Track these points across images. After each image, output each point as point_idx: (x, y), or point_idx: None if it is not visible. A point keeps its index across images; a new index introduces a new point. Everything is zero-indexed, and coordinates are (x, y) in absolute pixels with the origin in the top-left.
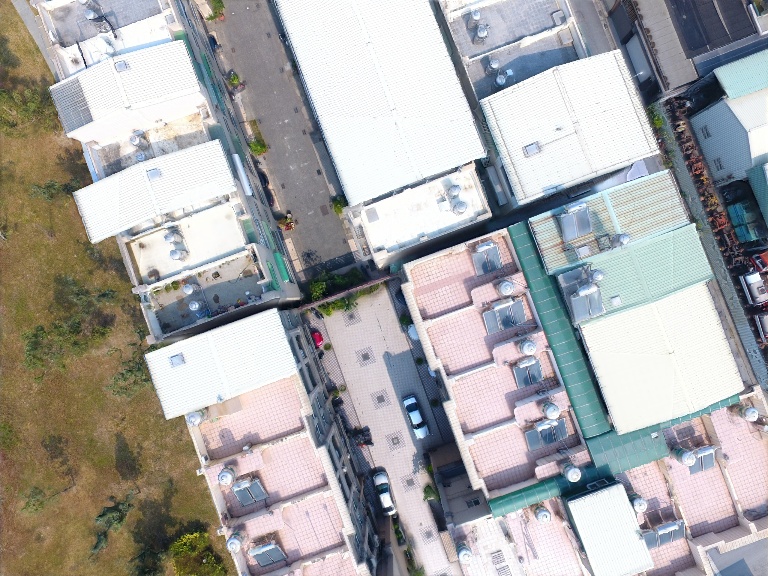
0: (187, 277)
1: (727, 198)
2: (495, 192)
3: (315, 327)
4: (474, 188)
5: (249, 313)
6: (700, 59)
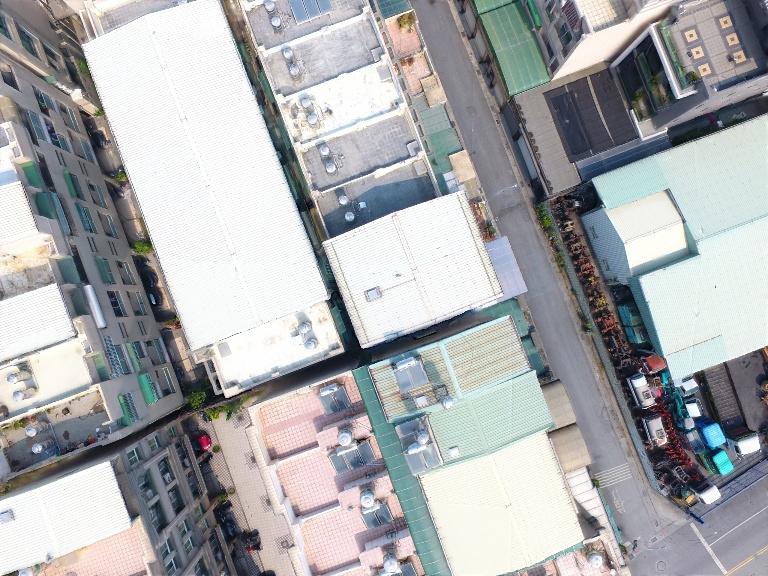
0: (36, 414)
1: (617, 297)
2: (351, 323)
3: (204, 429)
4: (329, 321)
5: (96, 453)
6: (583, 163)
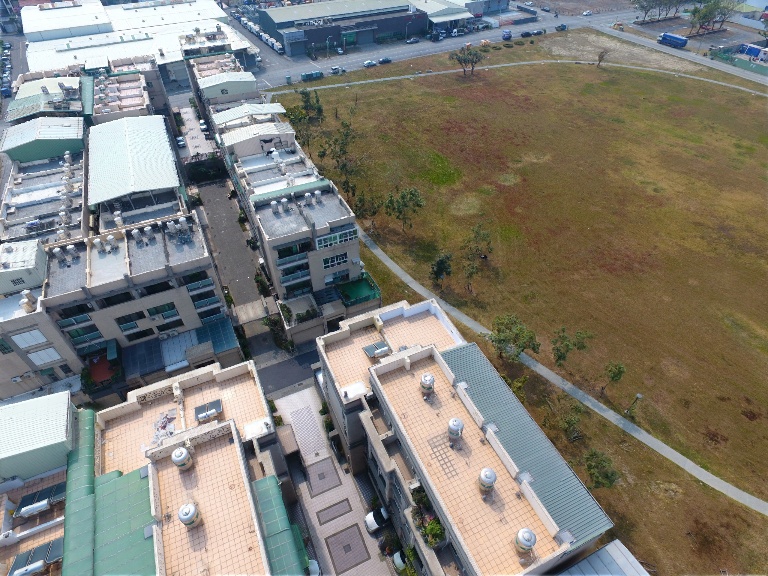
0: None
1: None
2: None
3: None
4: None
5: None
6: None
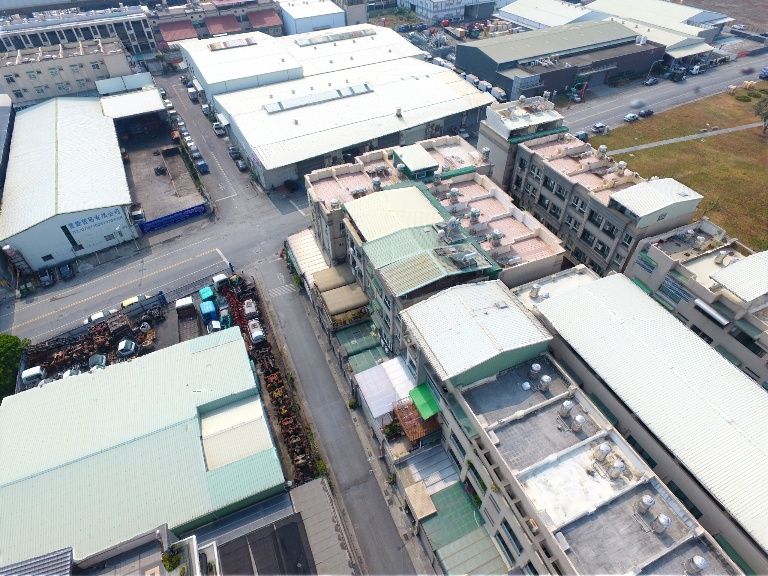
0: None
1: None
2: None
3: None
4: None
5: None
6: (286, 512)
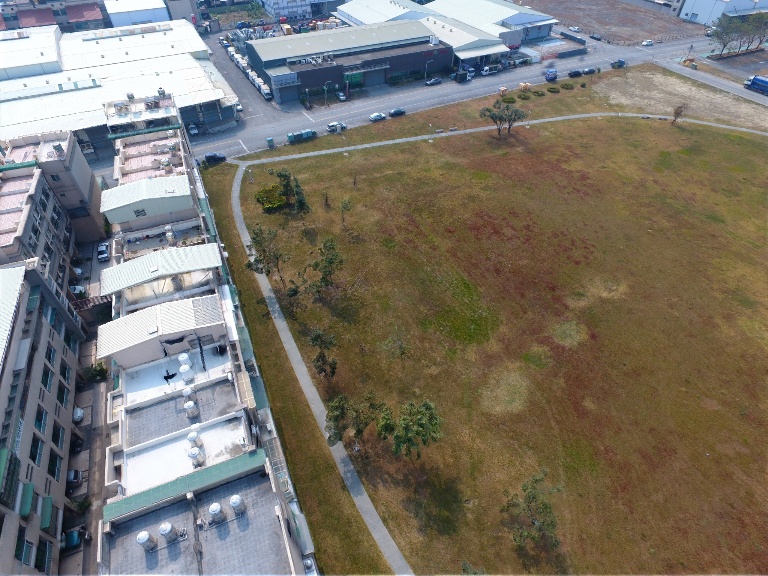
0: None
1: None
2: None
3: None
4: None
5: None
6: None
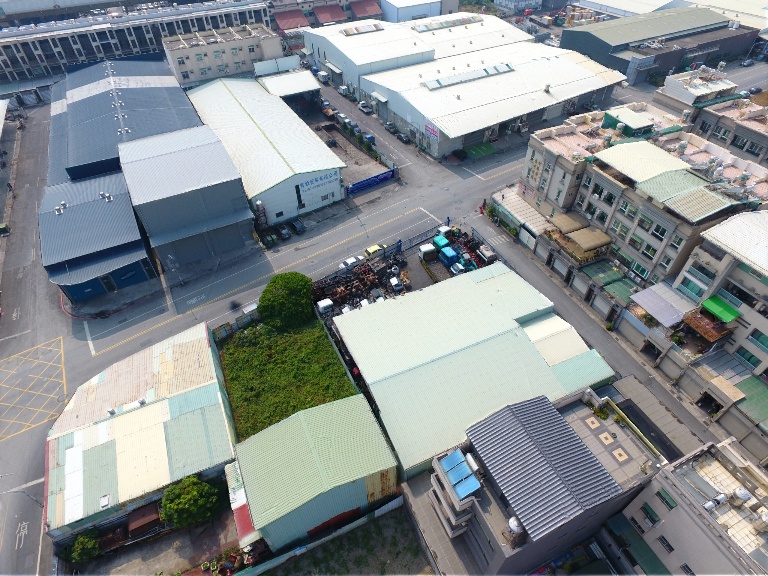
0: None
1: None
2: None
3: None
4: None
5: None
6: (618, 399)
